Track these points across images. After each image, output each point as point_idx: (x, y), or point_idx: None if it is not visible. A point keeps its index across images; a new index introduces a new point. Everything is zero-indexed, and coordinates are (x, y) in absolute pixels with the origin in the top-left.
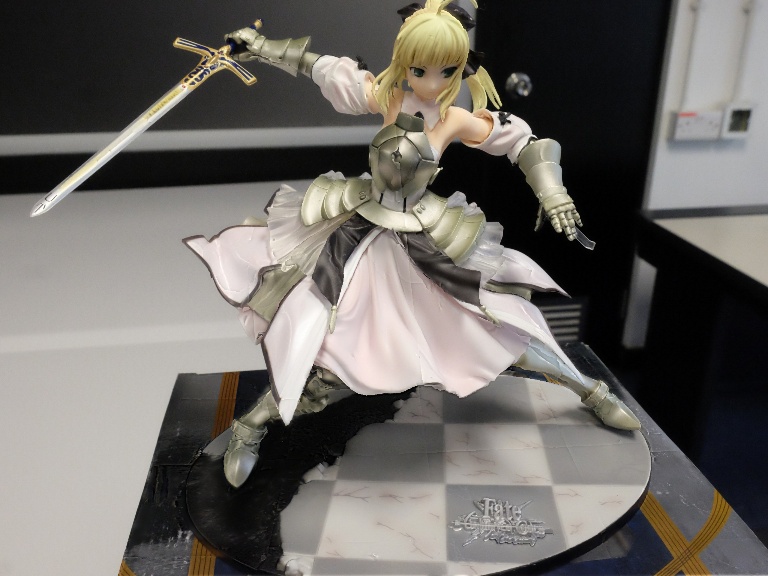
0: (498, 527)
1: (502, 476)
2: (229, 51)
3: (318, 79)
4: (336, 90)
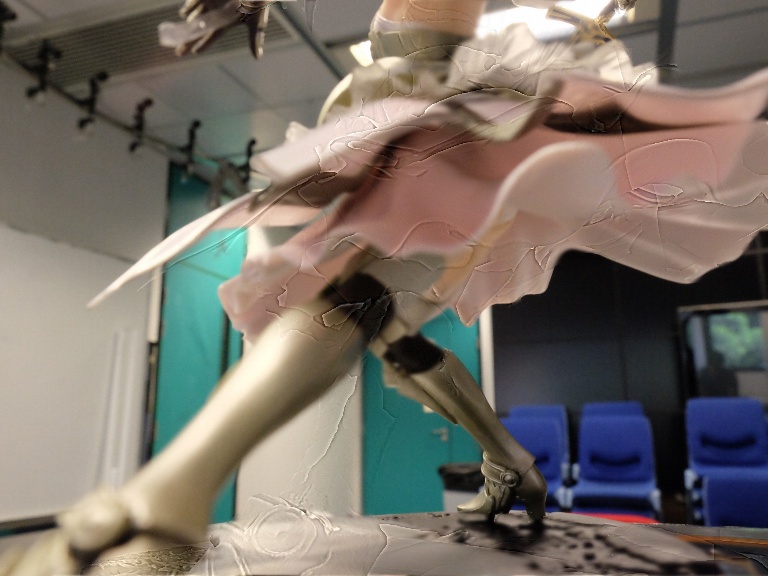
0: None
1: None
2: (602, 15)
3: None
4: None
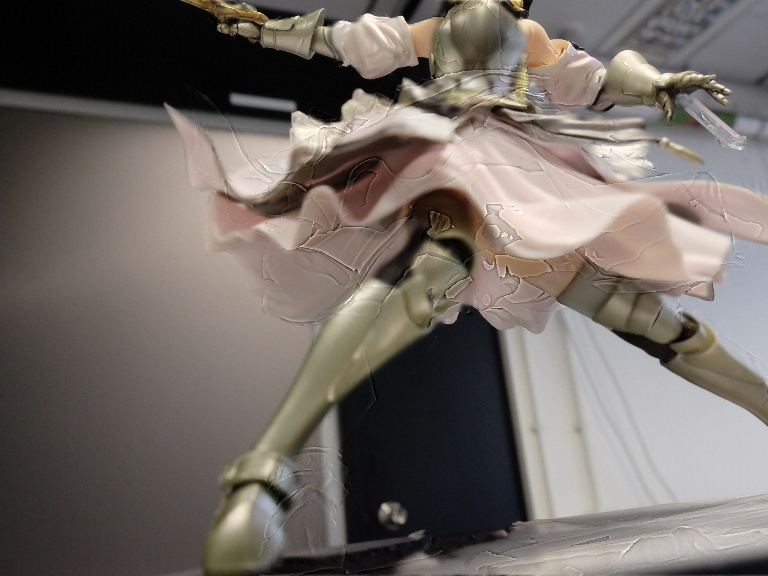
0: None
1: None
2: None
3: (333, 35)
4: (364, 27)
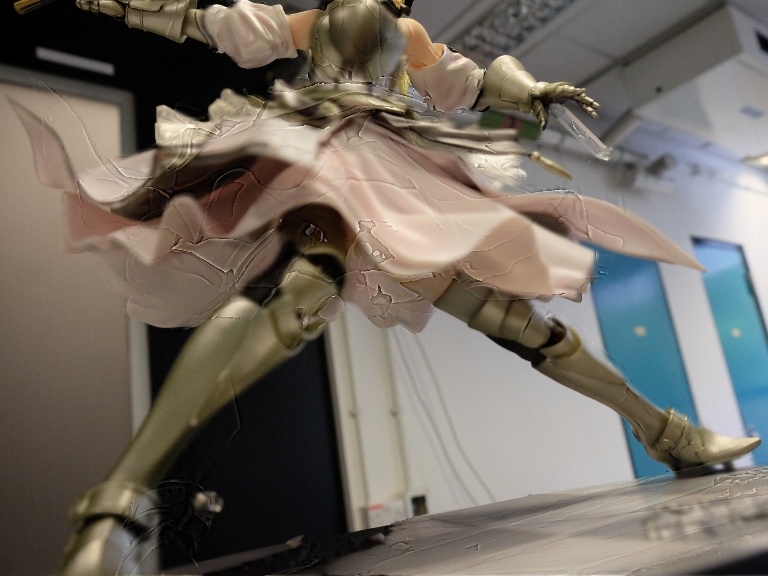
0: None
1: None
2: None
3: (206, 21)
4: (240, 15)
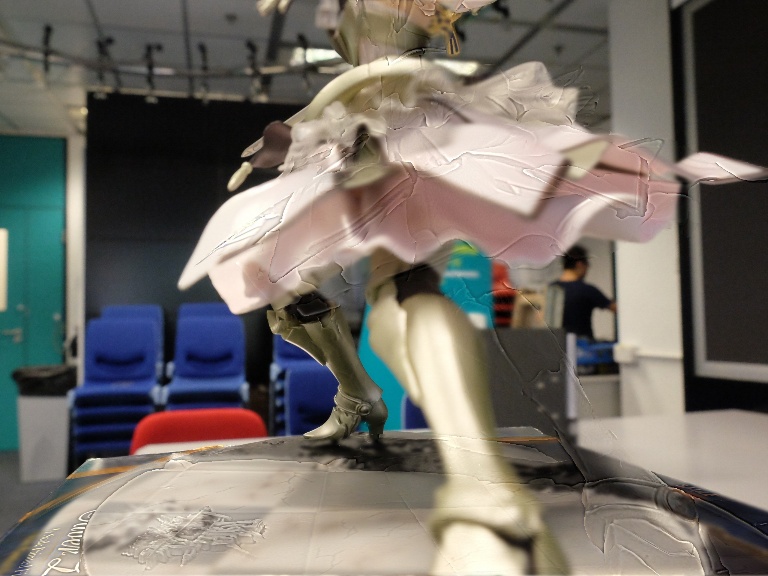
0: (180, 528)
1: (338, 540)
2: None
3: None
4: None
